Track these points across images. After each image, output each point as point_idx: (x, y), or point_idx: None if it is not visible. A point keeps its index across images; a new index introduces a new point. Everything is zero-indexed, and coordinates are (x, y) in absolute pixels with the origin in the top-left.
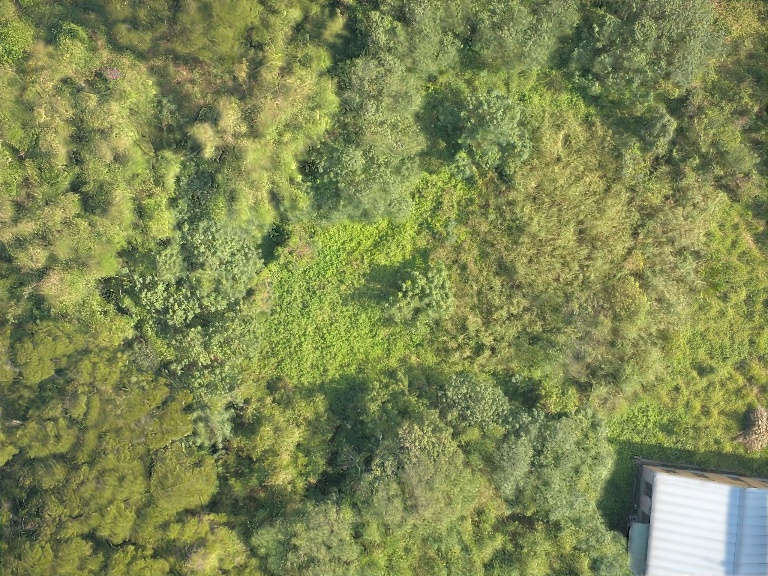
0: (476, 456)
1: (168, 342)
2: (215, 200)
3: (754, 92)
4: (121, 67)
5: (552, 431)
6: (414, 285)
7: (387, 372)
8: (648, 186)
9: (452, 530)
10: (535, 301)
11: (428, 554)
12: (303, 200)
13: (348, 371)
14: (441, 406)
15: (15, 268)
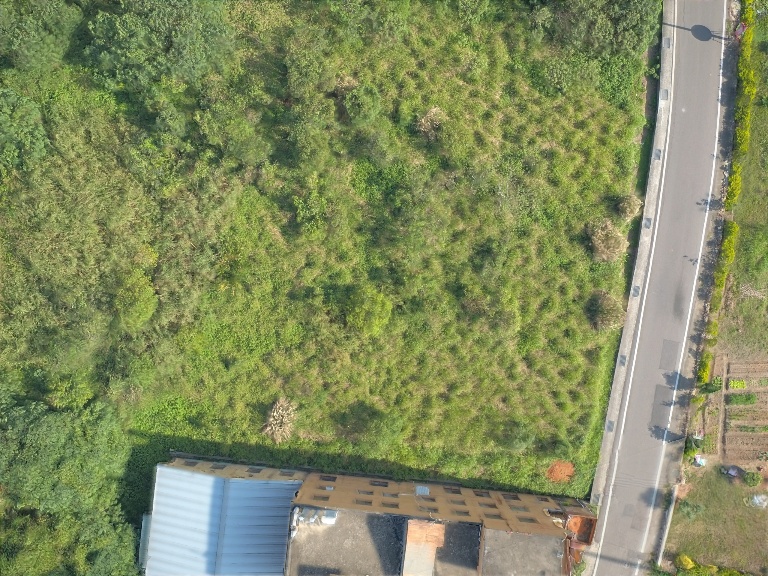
0: None
1: None
2: None
3: (267, 85)
4: None
5: (35, 424)
6: None
7: None
8: (169, 180)
9: None
10: (53, 296)
11: None
12: None
13: None
14: None
15: None
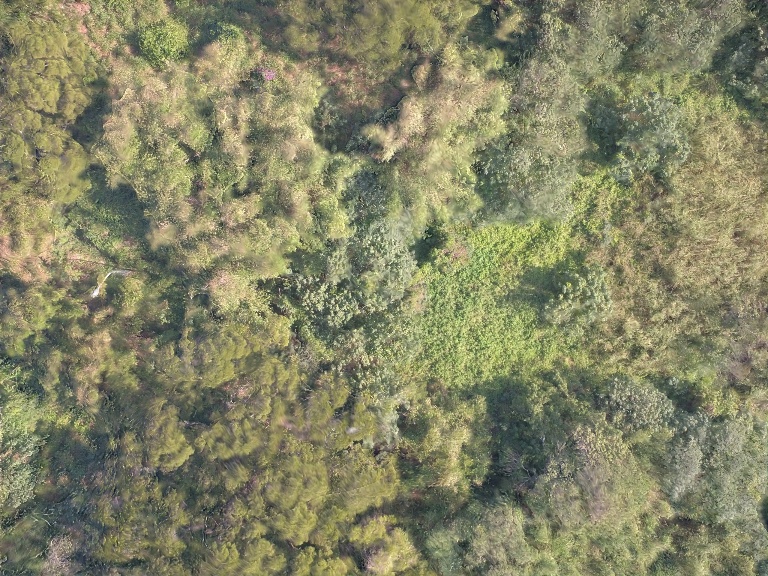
0: (644, 459)
1: (326, 343)
2: (390, 201)
3: None
4: (277, 68)
5: (722, 434)
6: (575, 287)
7: (541, 374)
8: None
9: (621, 533)
10: (693, 304)
11: (591, 557)
12: (469, 202)
13: (502, 373)
14: (604, 409)
15: (169, 268)
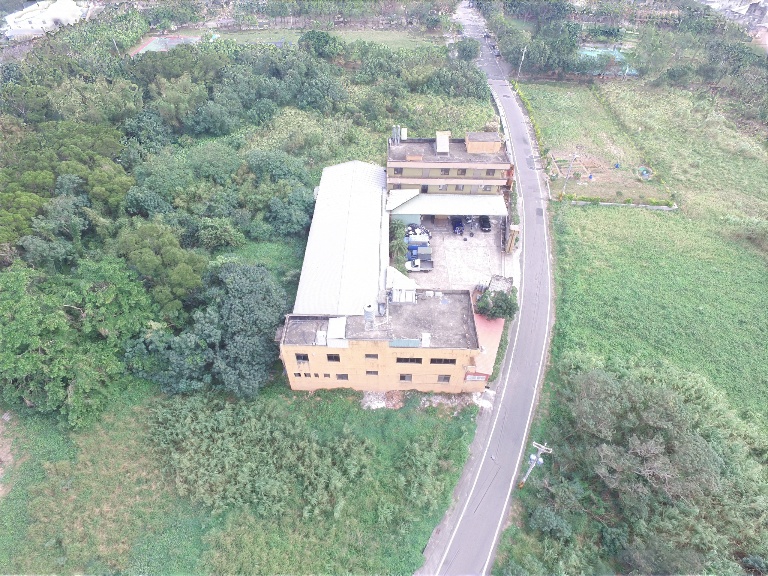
0: None
1: None
2: (154, 103)
3: None
4: None
5: None
6: None
7: None
8: None
9: None
10: None
11: None
12: (190, 115)
13: None
14: None
15: None
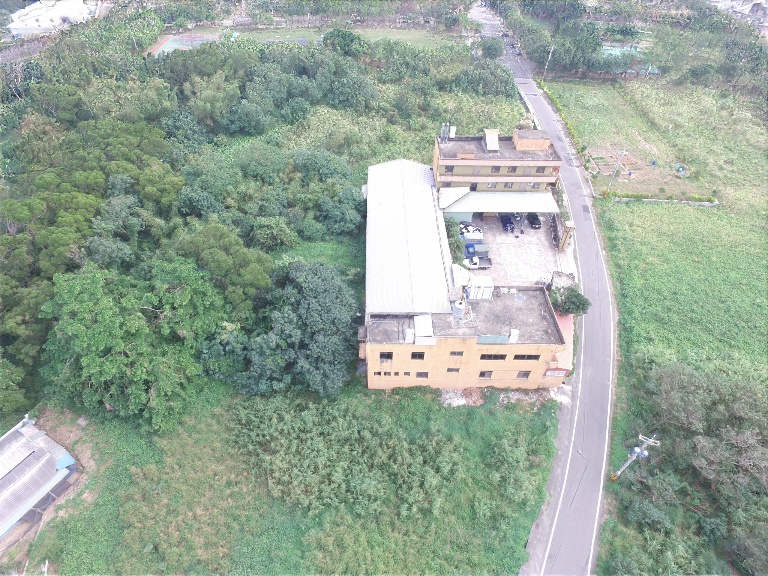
0: None
1: None
2: (190, 101)
3: None
4: None
5: None
6: None
7: None
8: None
9: None
10: None
11: None
12: (225, 114)
13: None
14: None
15: None
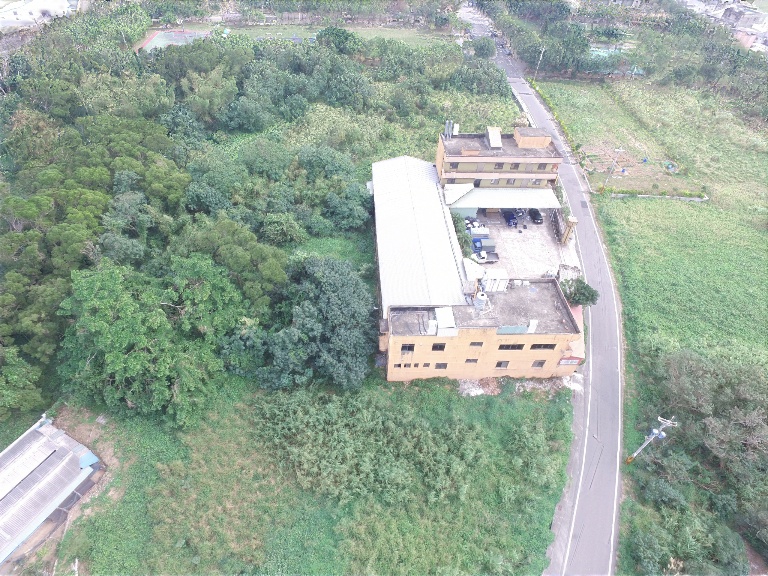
0: None
1: None
2: (188, 98)
3: None
4: None
5: None
6: None
7: None
8: None
9: None
10: None
11: None
12: (224, 110)
13: None
14: None
15: None
